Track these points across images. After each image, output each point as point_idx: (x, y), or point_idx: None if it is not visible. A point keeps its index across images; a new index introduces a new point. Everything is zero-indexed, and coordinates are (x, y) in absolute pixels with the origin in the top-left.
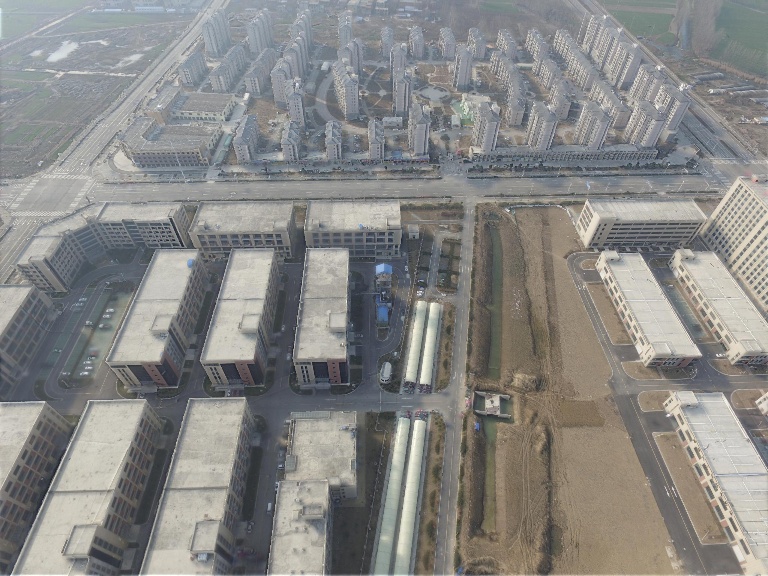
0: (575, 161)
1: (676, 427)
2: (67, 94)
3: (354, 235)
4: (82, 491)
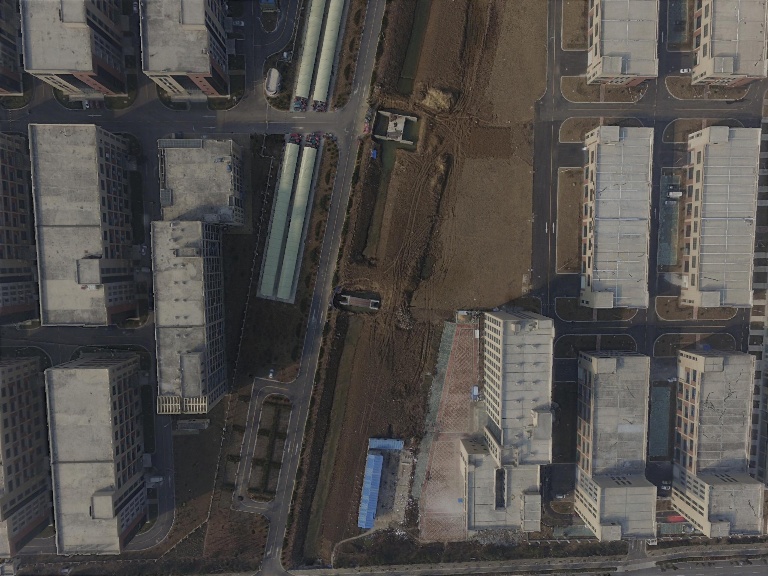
0: None
1: (587, 162)
2: None
3: None
4: None
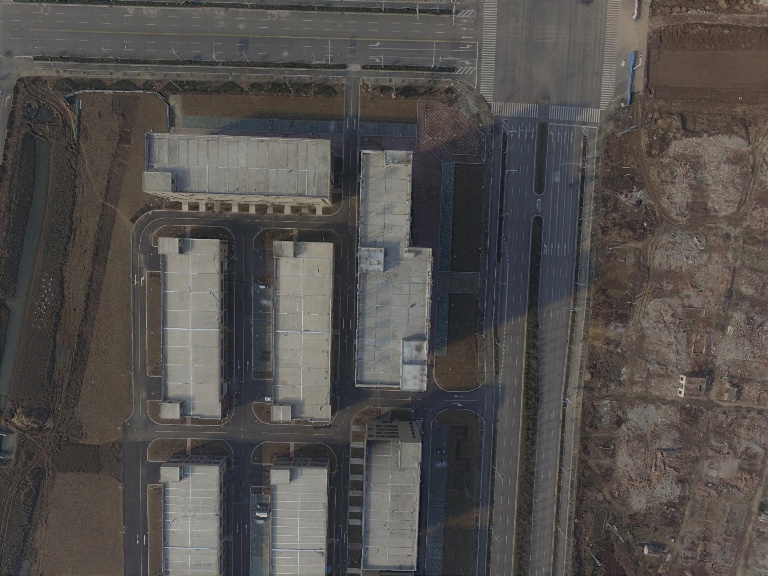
0: None
1: None
2: None
3: None
4: None
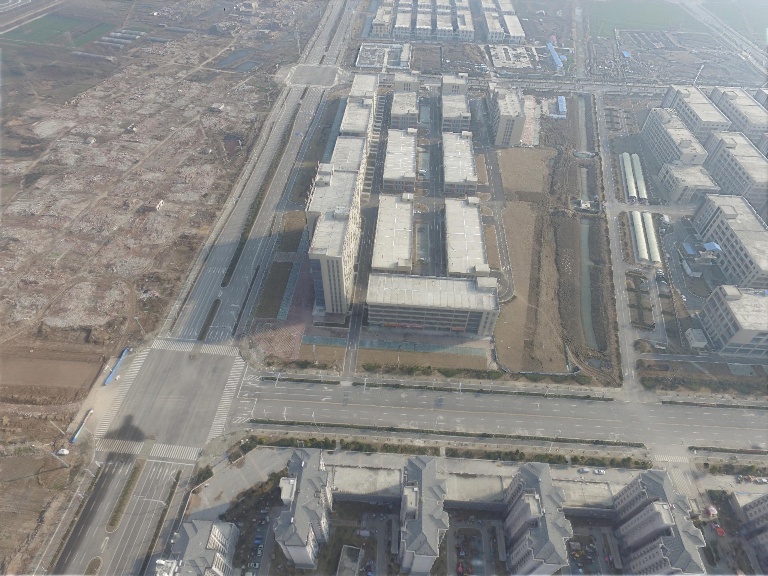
0: None
1: None
2: None
3: None
4: None
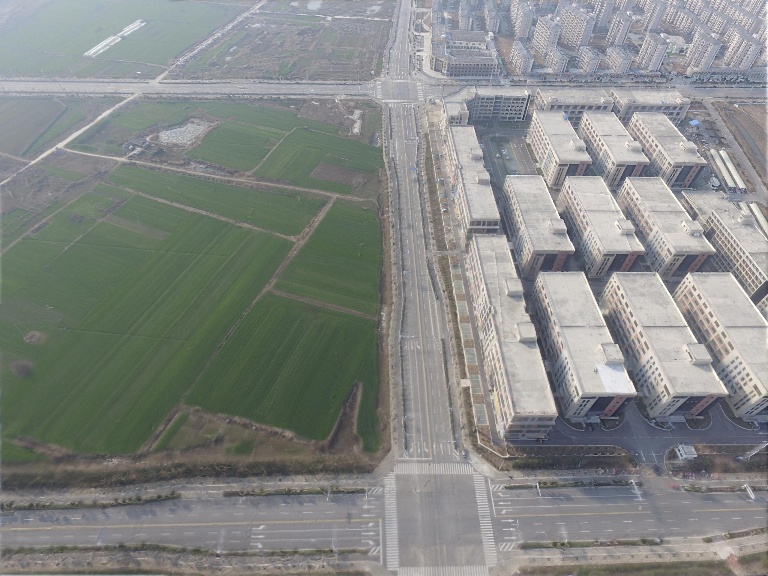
0: (767, 79)
1: None
2: (348, 31)
3: (655, 109)
4: (602, 211)
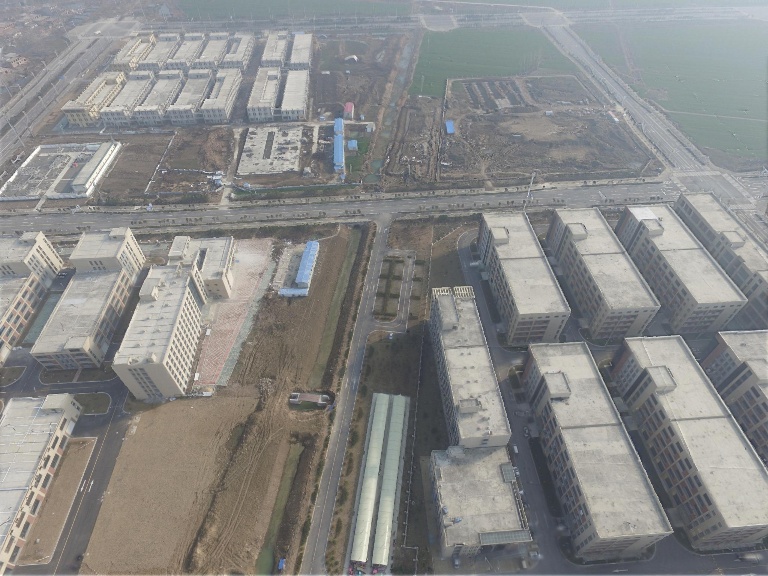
0: None
1: (9, 573)
2: None
3: None
4: (701, 418)
